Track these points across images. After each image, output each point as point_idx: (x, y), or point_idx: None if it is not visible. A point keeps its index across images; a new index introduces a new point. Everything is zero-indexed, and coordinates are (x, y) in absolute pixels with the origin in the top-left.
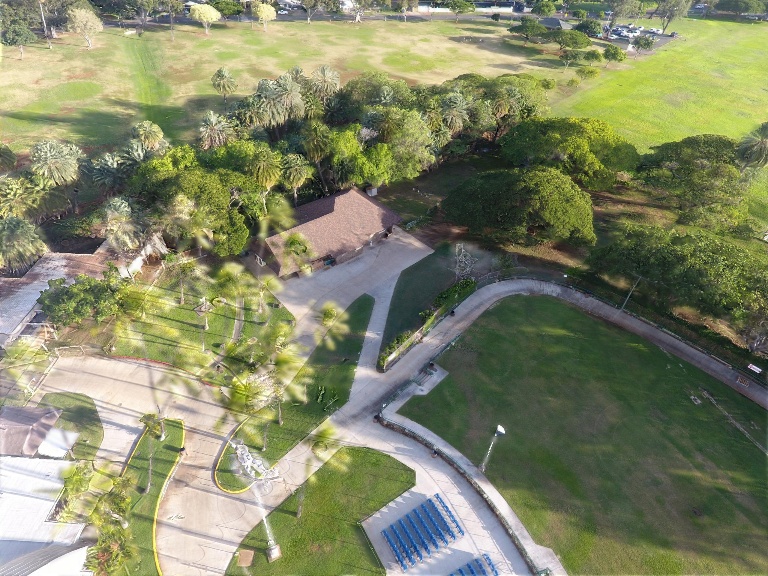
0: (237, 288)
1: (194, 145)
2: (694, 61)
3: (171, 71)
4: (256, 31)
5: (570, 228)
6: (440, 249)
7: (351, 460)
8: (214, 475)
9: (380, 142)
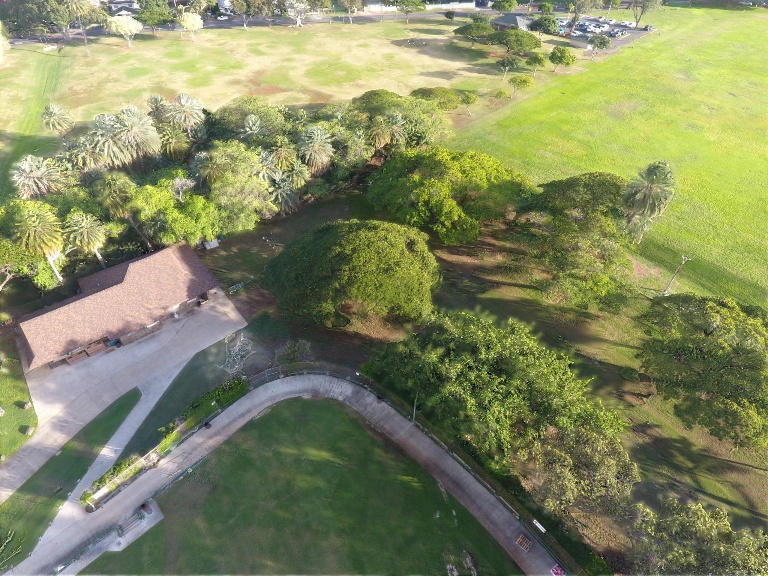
0: None
1: (8, 195)
2: (660, 60)
3: (68, 93)
4: (184, 41)
5: (387, 305)
6: (254, 322)
7: None
8: None
9: (209, 189)
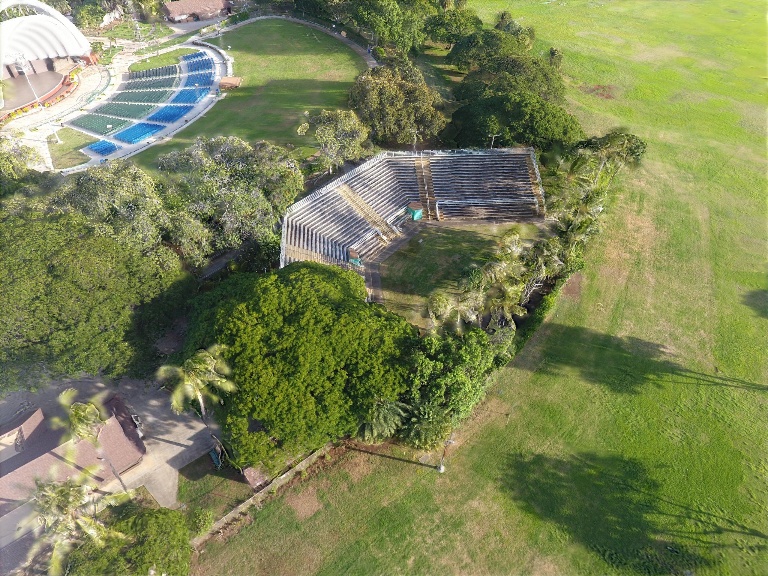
0: (153, 26)
1: None
2: None
3: None
4: None
5: None
6: None
7: (180, 50)
8: (133, 53)
9: None
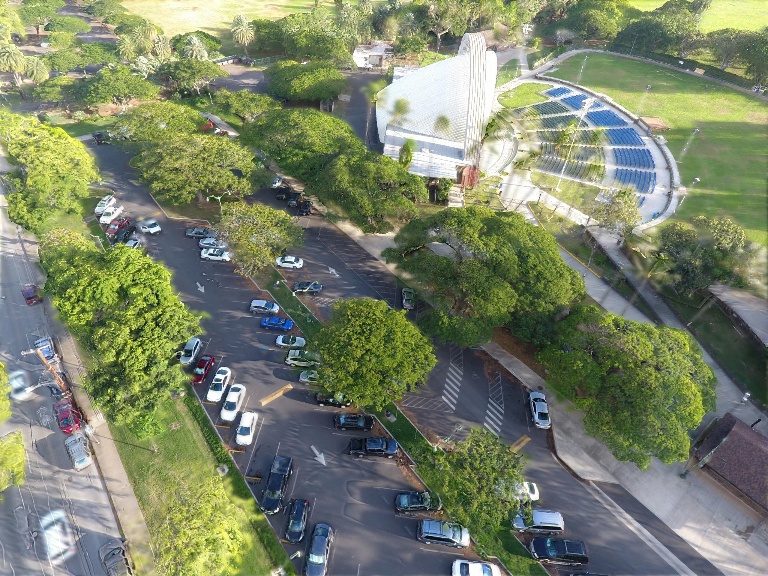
0: None
1: None
2: None
3: None
4: None
5: (607, 32)
6: (543, 49)
7: None
8: None
9: None
